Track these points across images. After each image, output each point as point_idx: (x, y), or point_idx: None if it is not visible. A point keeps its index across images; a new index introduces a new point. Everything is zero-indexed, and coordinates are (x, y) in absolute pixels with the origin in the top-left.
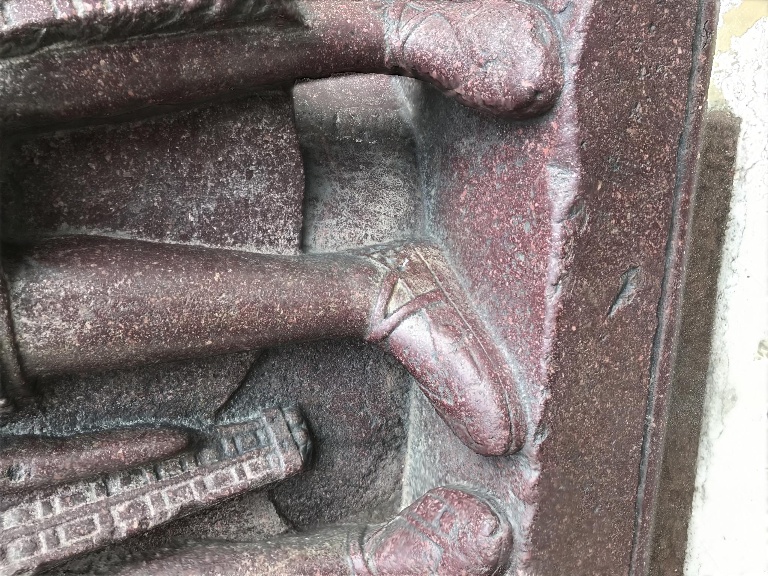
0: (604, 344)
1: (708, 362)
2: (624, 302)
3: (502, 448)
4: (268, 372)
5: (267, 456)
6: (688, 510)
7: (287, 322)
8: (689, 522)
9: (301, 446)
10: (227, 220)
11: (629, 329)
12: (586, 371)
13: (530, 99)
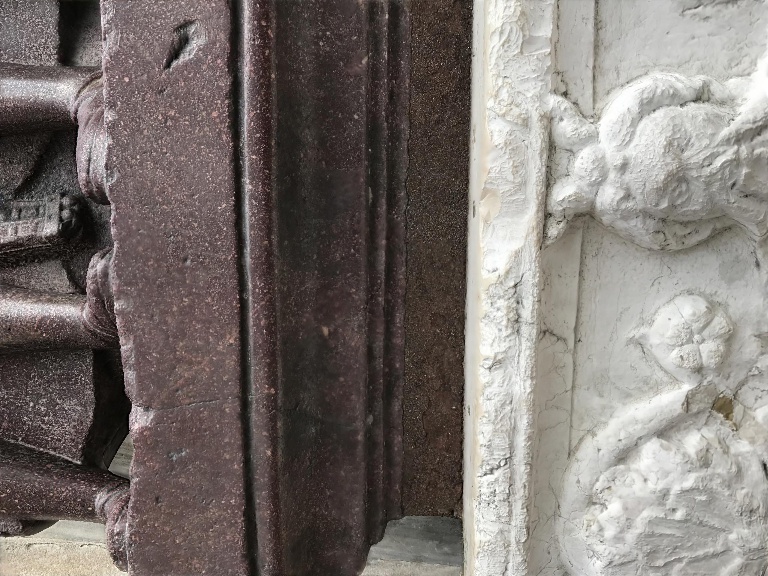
0: (166, 97)
1: (467, 168)
2: (184, 56)
3: (85, 188)
4: (58, 166)
5: (39, 224)
6: (461, 340)
7: (7, 106)
8: (464, 354)
9: (66, 220)
10: (2, 40)
11: (194, 83)
12: (149, 122)
13: None
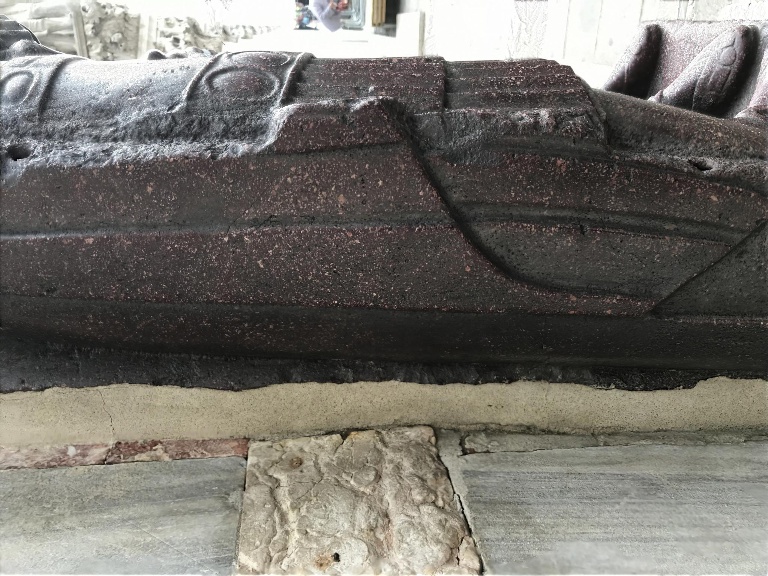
0: None
1: None
2: None
3: None
4: None
5: None
6: None
7: None
8: None
9: None
10: None
11: None
12: None
13: (648, 32)
